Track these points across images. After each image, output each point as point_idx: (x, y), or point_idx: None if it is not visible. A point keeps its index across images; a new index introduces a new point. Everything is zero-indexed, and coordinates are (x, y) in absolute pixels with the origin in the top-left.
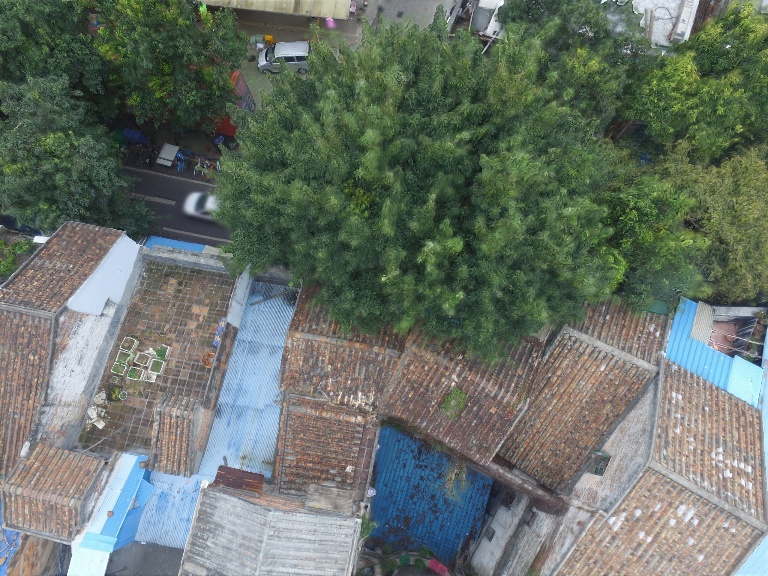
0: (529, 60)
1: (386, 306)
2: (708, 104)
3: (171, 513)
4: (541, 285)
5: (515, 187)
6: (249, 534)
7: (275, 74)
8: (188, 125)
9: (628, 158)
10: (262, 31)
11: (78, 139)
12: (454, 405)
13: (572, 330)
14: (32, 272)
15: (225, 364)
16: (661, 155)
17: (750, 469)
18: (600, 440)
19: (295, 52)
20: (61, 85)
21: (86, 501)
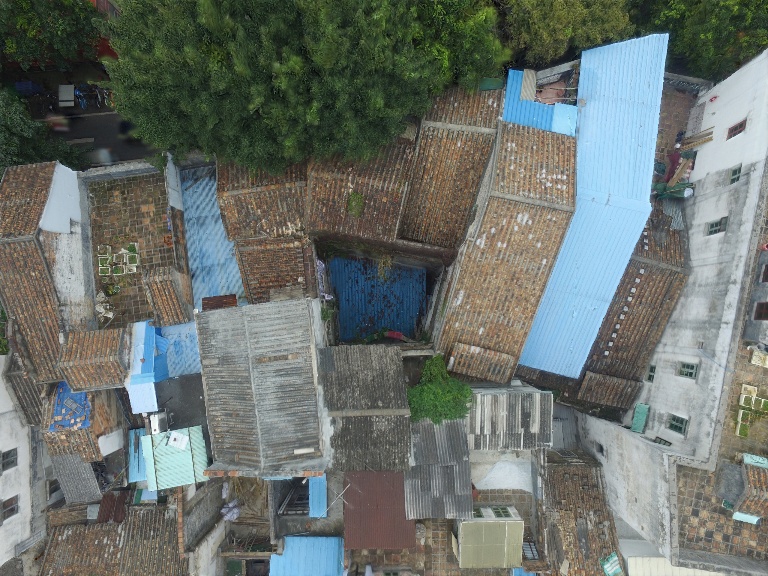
0: None
1: (280, 147)
2: None
3: (187, 352)
4: (385, 90)
5: (325, 11)
6: (235, 326)
7: None
8: (70, 58)
9: None
10: None
11: None
12: (355, 205)
13: (428, 122)
14: (0, 213)
15: (183, 239)
16: None
17: (565, 177)
18: (473, 200)
19: None
20: None
21: (121, 355)
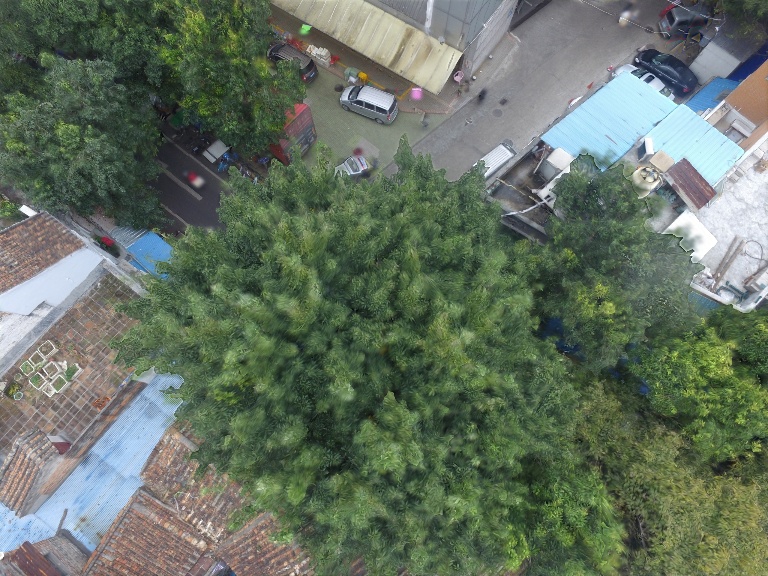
0: (547, 263)
1: None
2: (731, 404)
3: None
4: None
5: None
6: None
7: (353, 113)
8: None
9: (616, 410)
10: (362, 65)
11: (98, 132)
12: None
13: None
14: None
15: (115, 416)
16: (647, 434)
17: None
18: None
19: (377, 102)
20: (105, 76)
21: None
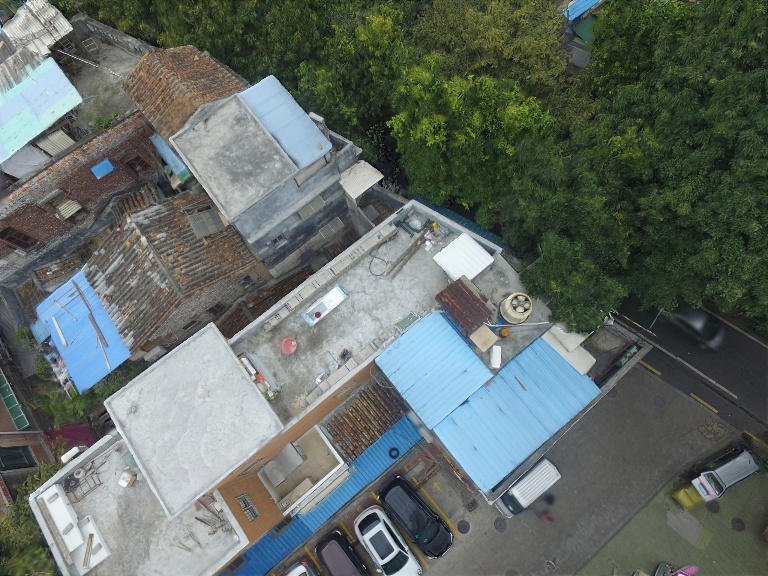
0: None
1: None
2: None
3: None
4: None
5: None
6: None
7: None
8: None
9: None
10: None
11: None
12: None
13: None
14: None
15: None
16: None
17: None
18: None
19: None
20: None
21: None
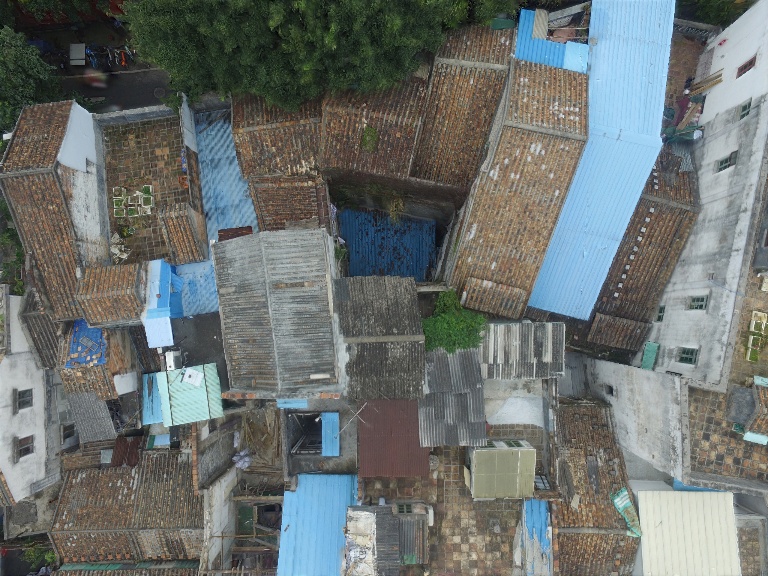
0: None
1: (295, 79)
2: None
3: (202, 292)
4: (400, 20)
5: None
6: (252, 253)
7: None
8: (83, 10)
9: None
10: None
11: None
12: (369, 140)
13: (442, 59)
14: (18, 148)
15: (198, 180)
16: None
17: (577, 109)
18: (485, 139)
19: None
20: None
21: (137, 289)
